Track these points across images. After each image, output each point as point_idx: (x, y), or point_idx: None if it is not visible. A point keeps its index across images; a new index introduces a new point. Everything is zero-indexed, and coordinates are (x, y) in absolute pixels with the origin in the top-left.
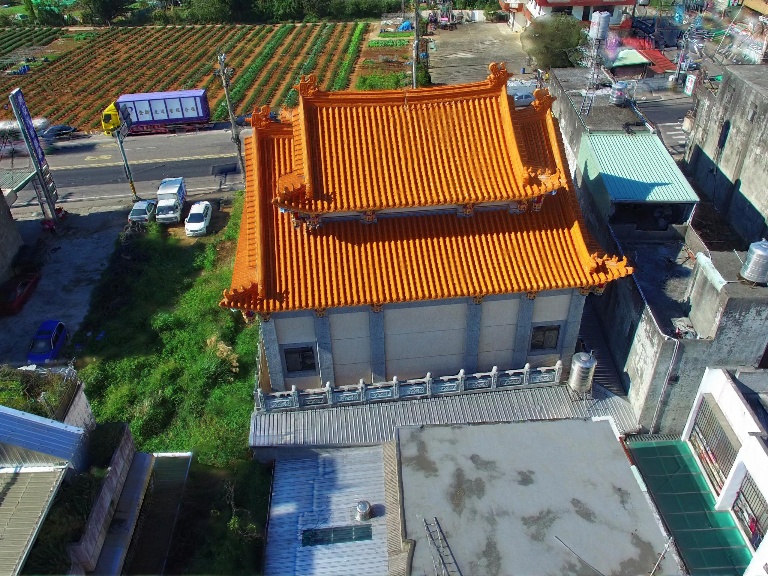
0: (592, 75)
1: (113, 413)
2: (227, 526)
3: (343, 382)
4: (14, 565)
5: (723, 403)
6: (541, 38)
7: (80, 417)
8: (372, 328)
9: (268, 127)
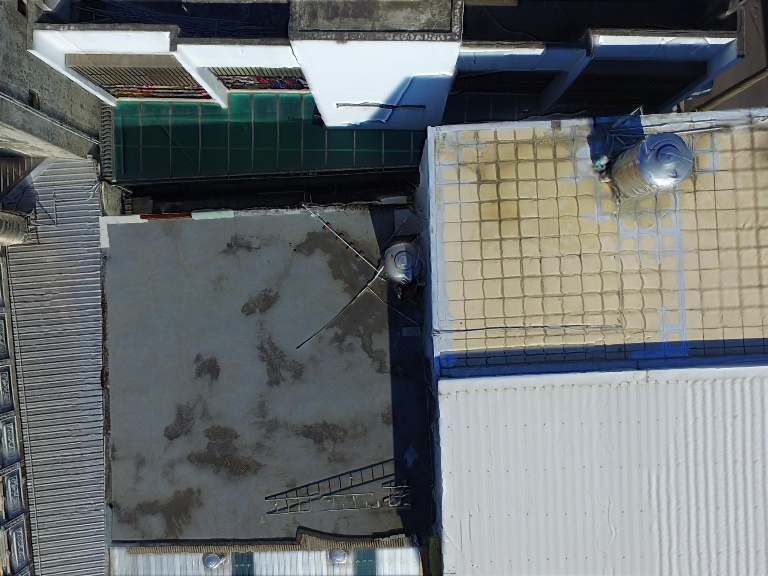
0: None
1: None
2: None
3: None
4: None
5: (93, 49)
6: None
7: None
8: None
9: None
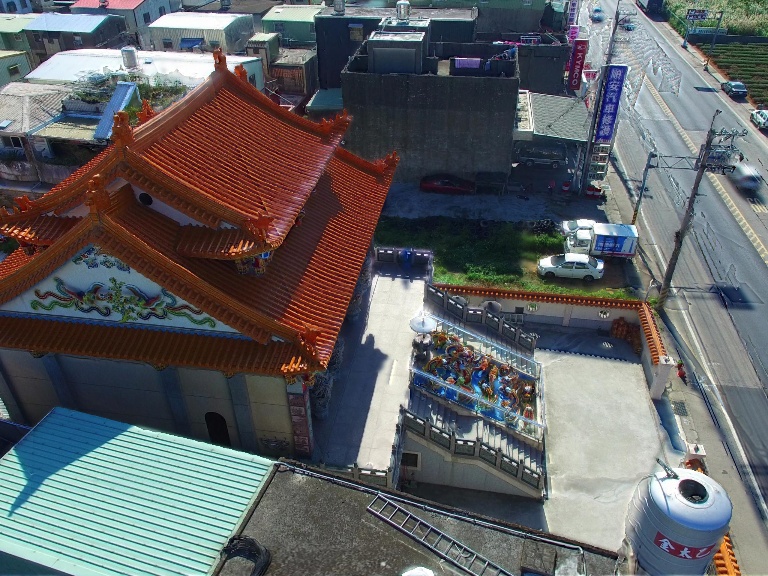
0: None
1: None
2: None
3: None
4: (51, 135)
5: None
6: None
7: None
8: None
9: None
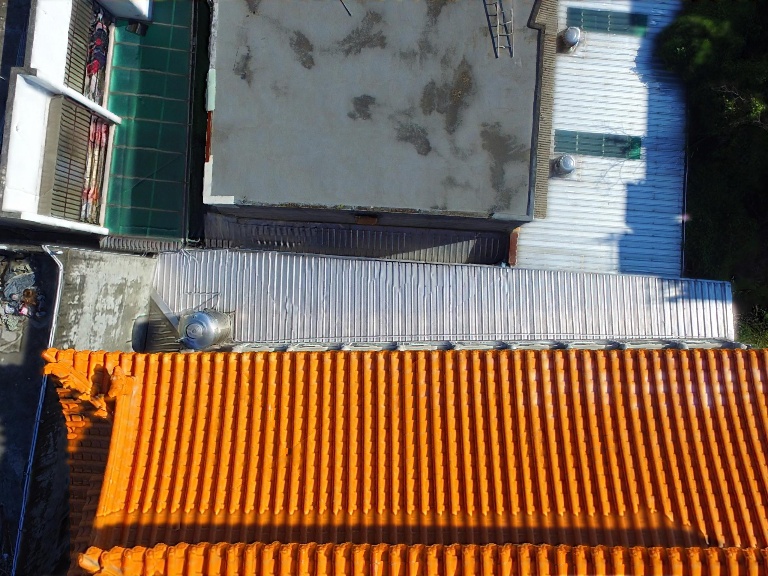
0: None
1: None
2: None
3: None
4: None
5: None
6: None
7: None
8: None
9: None
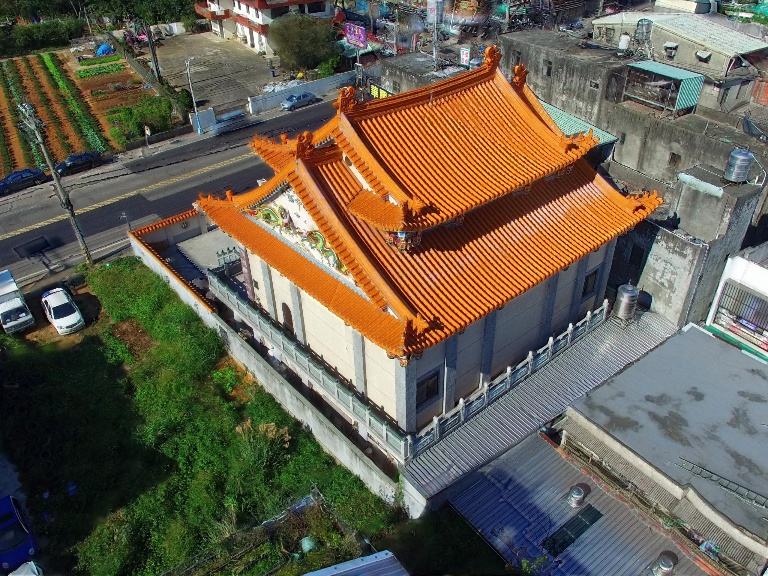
0: (436, 57)
1: (187, 561)
2: (523, 573)
3: (458, 396)
4: None
5: (749, 281)
6: (290, 38)
7: None
8: (488, 328)
9: (311, 155)
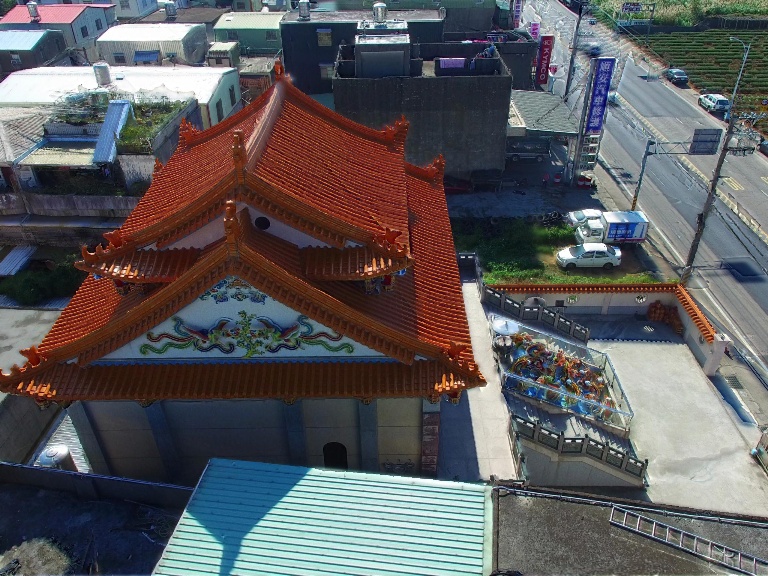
0: None
1: None
2: None
3: None
4: (41, 162)
5: None
6: None
7: (147, 170)
8: None
9: None
